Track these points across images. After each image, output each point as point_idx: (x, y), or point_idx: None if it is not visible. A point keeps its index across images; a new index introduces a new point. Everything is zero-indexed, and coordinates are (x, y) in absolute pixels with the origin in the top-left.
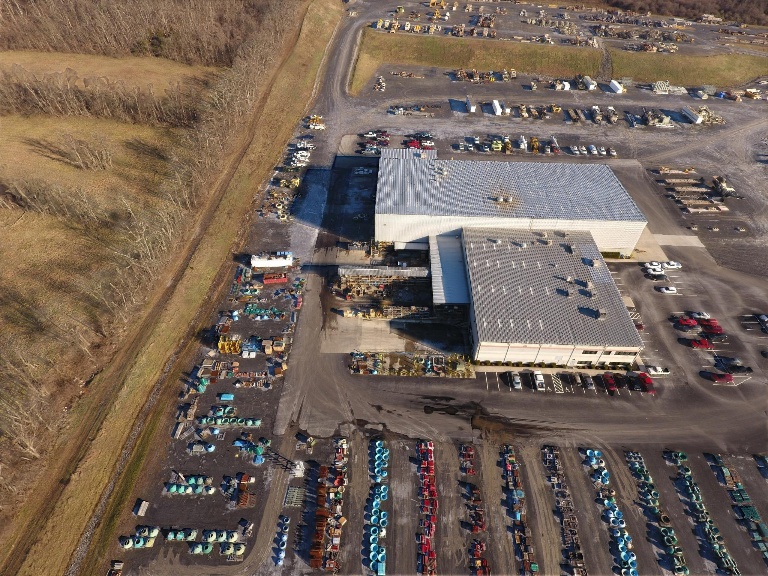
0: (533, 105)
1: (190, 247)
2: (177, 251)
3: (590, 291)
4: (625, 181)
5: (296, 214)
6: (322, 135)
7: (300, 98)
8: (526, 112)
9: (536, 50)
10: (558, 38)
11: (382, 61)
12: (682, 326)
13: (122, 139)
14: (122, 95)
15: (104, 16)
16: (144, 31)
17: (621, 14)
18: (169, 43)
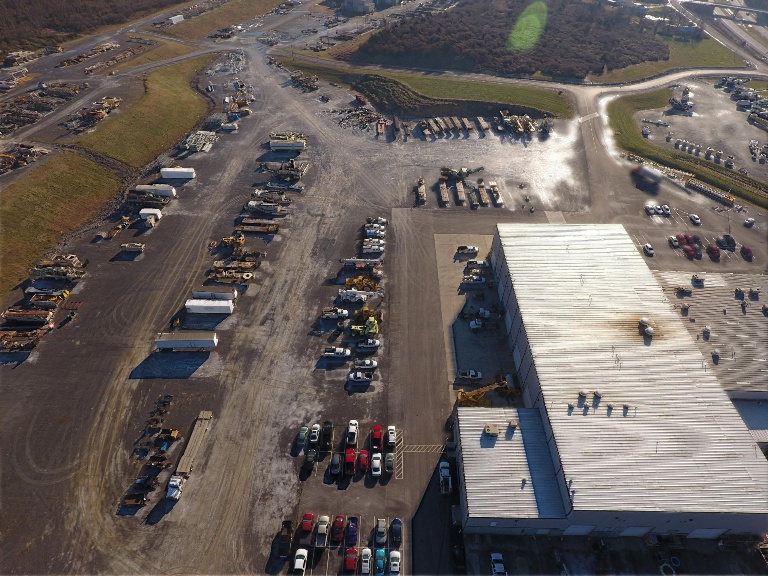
0: (204, 262)
1: None
2: None
3: (755, 292)
4: (448, 228)
5: None
6: None
7: None
8: None
9: None
10: None
11: None
12: (695, 255)
13: None
14: None
15: None
16: None
17: None
18: None
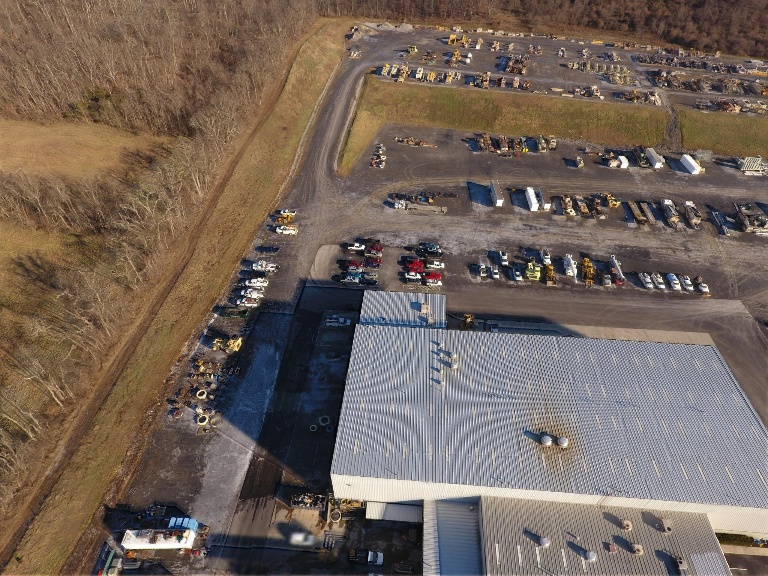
0: (580, 193)
1: (34, 500)
2: (8, 514)
3: None
4: (730, 348)
5: (224, 412)
6: (291, 245)
7: (272, 180)
8: (572, 206)
9: (581, 108)
10: (608, 90)
11: (385, 120)
12: None
13: (12, 257)
14: (17, 194)
15: (30, 72)
16: (80, 91)
17: (683, 54)
18: (108, 108)
